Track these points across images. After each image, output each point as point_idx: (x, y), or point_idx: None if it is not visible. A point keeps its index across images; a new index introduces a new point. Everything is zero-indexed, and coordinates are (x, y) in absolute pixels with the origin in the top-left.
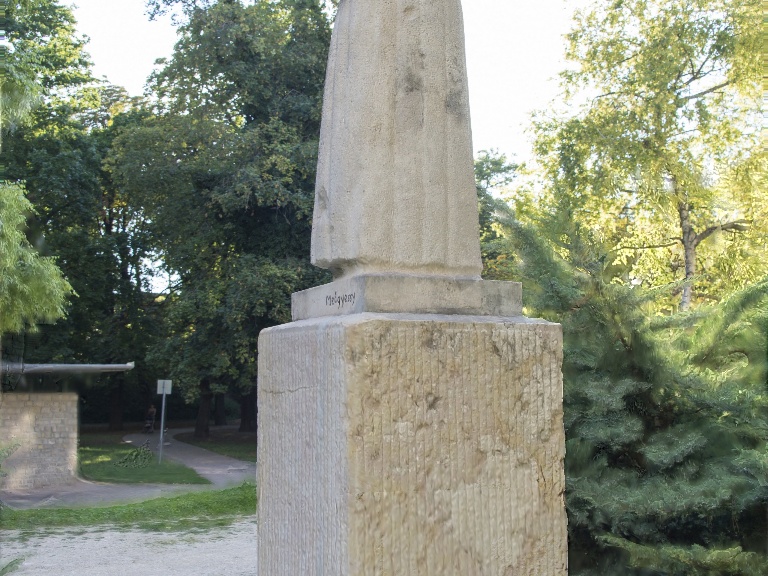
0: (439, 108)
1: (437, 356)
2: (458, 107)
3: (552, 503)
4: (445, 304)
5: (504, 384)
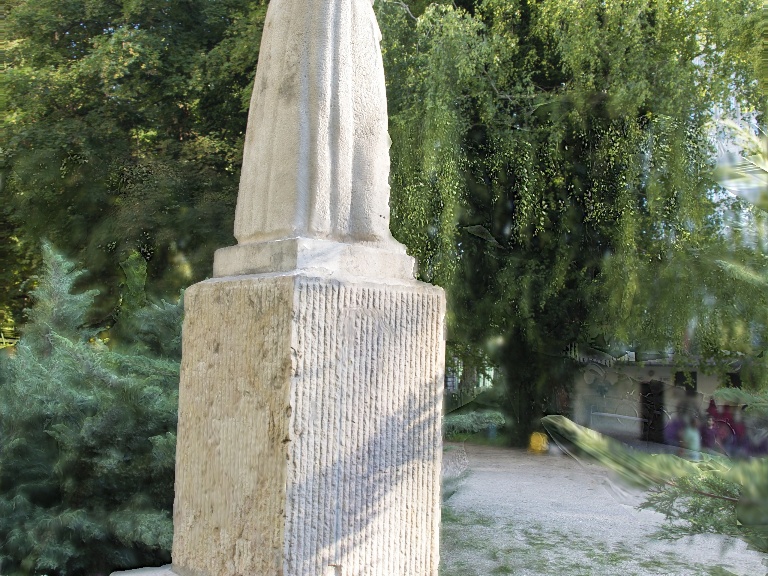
0: (273, 98)
1: (220, 310)
2: (290, 89)
3: (278, 448)
4: (250, 266)
5: (254, 333)
